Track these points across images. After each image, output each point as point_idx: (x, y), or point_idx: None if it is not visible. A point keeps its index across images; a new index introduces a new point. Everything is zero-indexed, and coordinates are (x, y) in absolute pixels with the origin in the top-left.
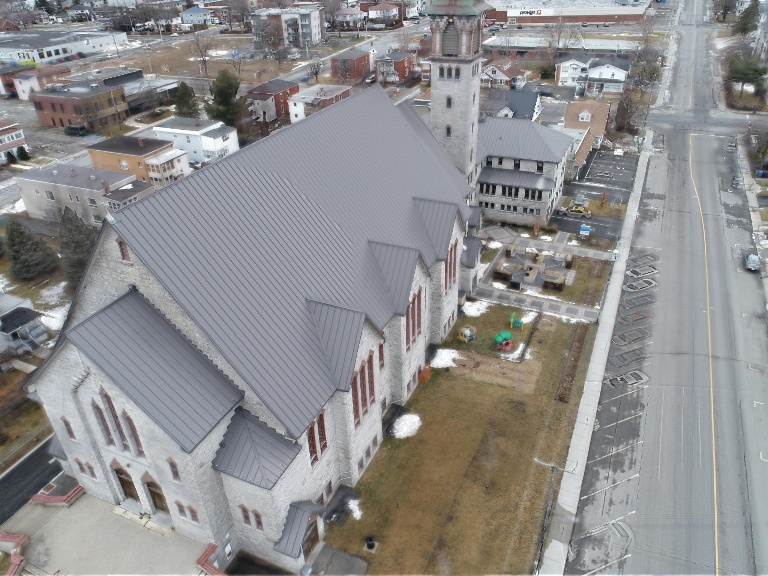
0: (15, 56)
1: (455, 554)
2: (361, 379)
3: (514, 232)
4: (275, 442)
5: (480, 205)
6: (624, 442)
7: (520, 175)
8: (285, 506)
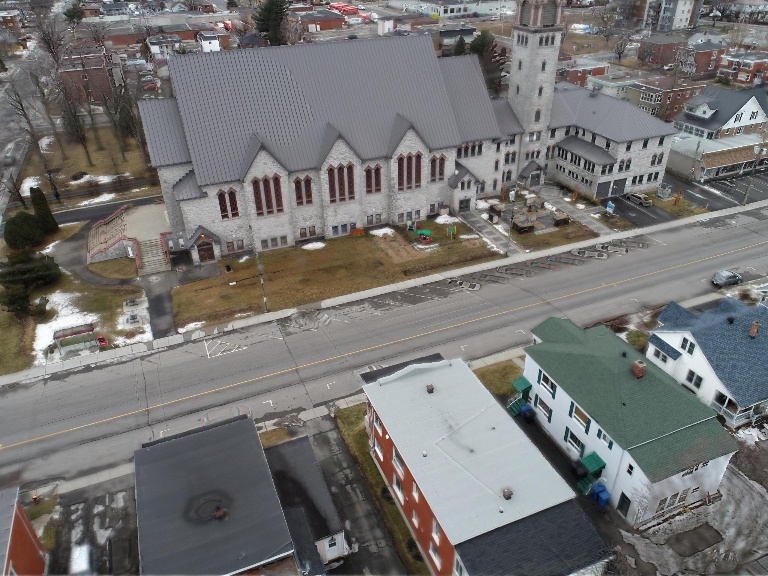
0: (419, 8)
1: (251, 289)
2: (267, 188)
3: (562, 194)
4: (196, 187)
5: (557, 167)
6: (401, 302)
7: (591, 148)
8: (195, 223)
